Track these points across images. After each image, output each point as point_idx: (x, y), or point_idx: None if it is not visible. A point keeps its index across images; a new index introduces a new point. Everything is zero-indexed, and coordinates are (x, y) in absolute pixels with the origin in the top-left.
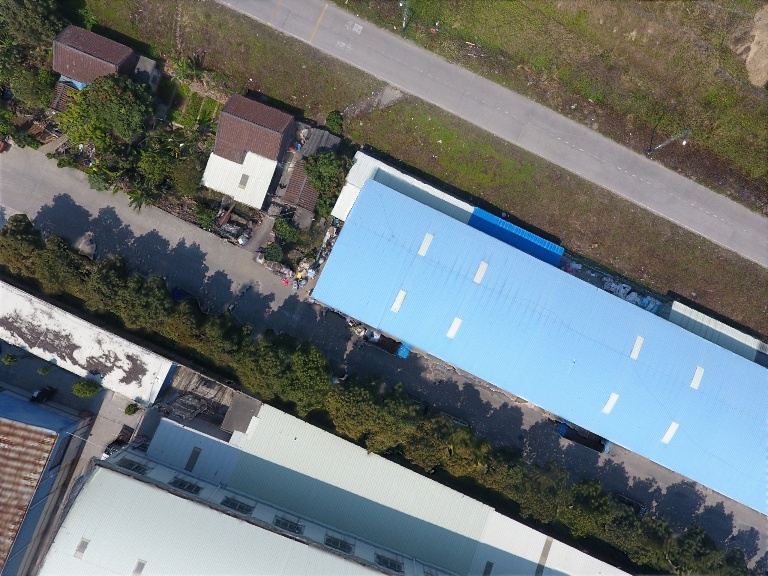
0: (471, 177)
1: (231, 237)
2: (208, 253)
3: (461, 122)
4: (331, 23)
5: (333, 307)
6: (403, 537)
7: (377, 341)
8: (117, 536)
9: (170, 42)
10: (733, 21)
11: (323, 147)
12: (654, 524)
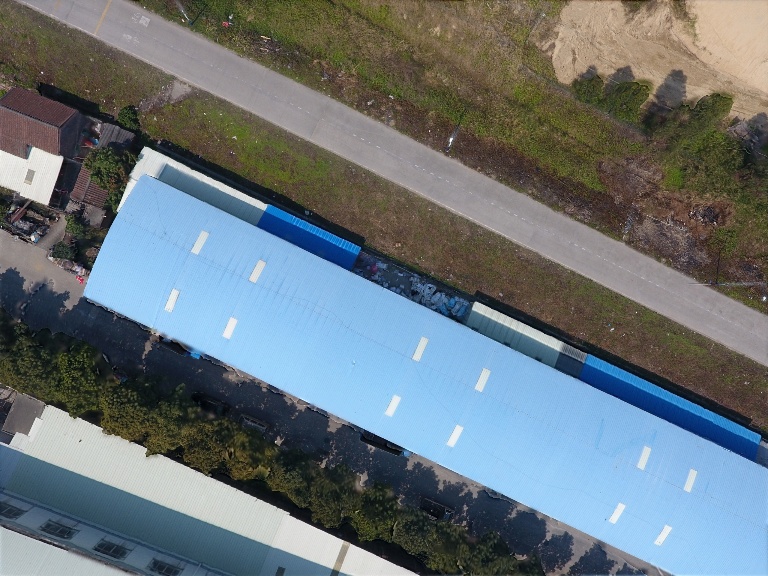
0: (271, 174)
1: (23, 234)
2: None
3: (252, 118)
4: (117, 15)
5: (106, 306)
6: (190, 542)
7: (170, 341)
8: None
9: None
10: (537, 17)
11: (114, 142)
12: (448, 529)
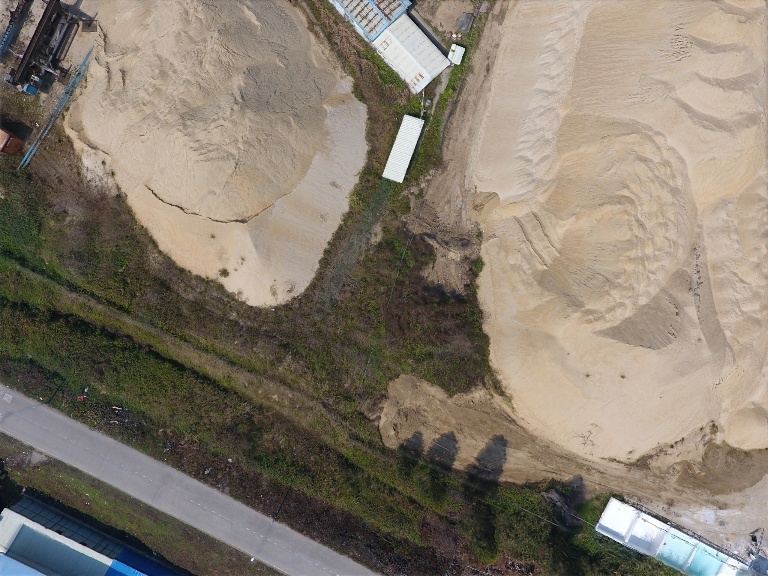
0: (122, 522)
1: None
2: None
3: (101, 484)
4: None
5: None
6: None
7: None
8: None
9: None
10: (365, 391)
11: None
12: None
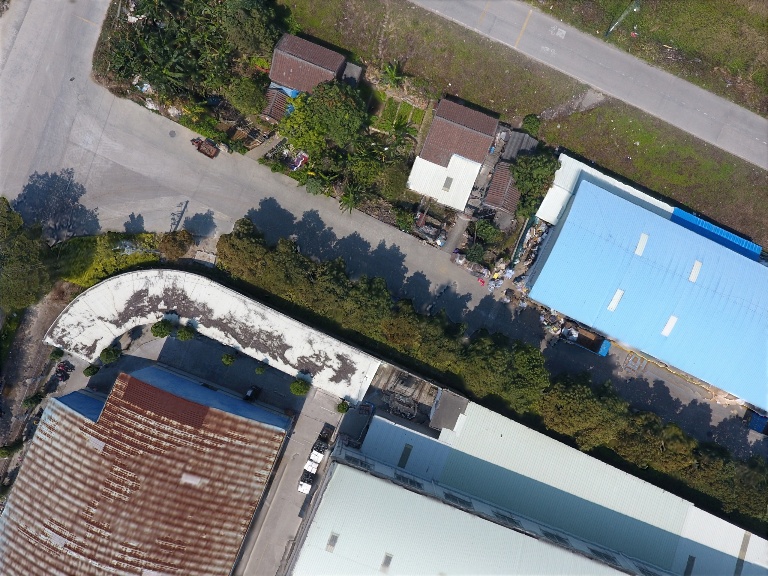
0: (664, 178)
1: (430, 239)
2: (407, 254)
3: (662, 124)
4: (535, 28)
5: (549, 306)
6: (608, 532)
7: (576, 339)
8: (363, 530)
9: (372, 49)
10: None
11: (523, 150)
12: None
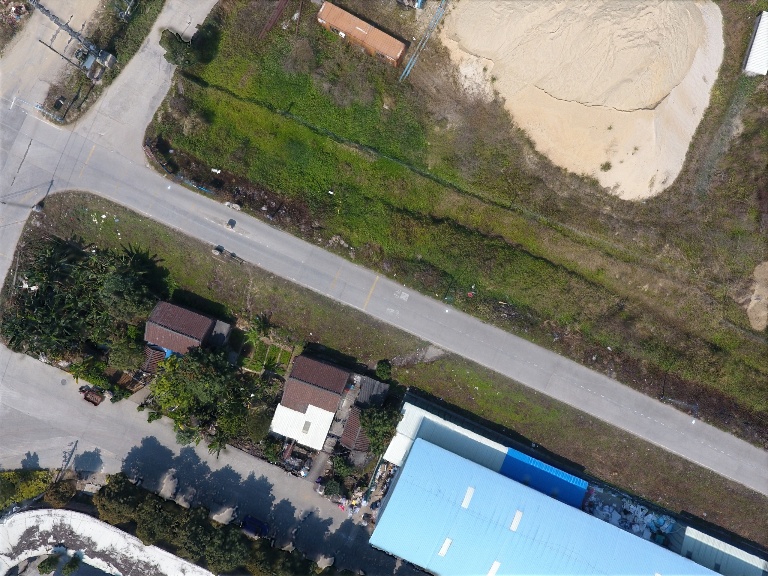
0: (504, 415)
1: (294, 470)
2: (274, 484)
3: (496, 375)
4: (382, 292)
5: (388, 551)
6: None
7: None
8: None
9: (241, 303)
10: (735, 276)
11: (375, 395)
12: None
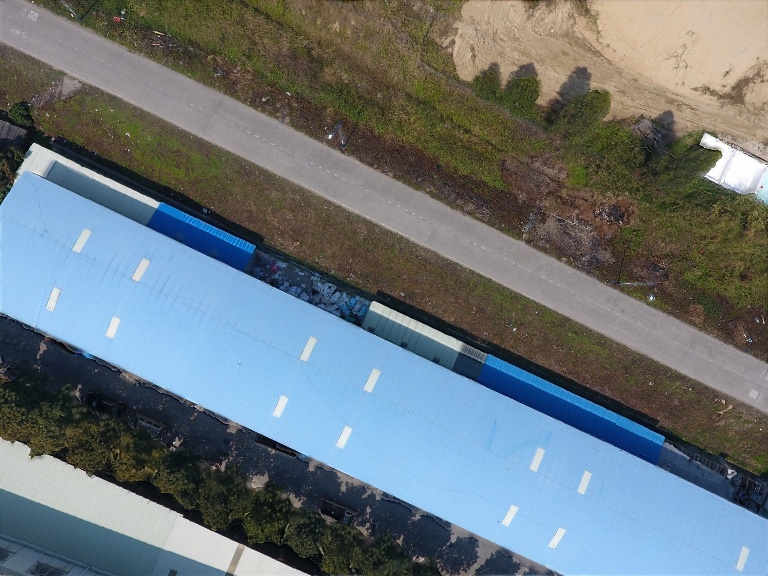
0: (167, 171)
1: None
2: None
3: (144, 114)
4: (4, 10)
5: None
6: (80, 544)
7: None
8: None
9: None
10: (437, 13)
11: (4, 139)
12: (343, 531)
